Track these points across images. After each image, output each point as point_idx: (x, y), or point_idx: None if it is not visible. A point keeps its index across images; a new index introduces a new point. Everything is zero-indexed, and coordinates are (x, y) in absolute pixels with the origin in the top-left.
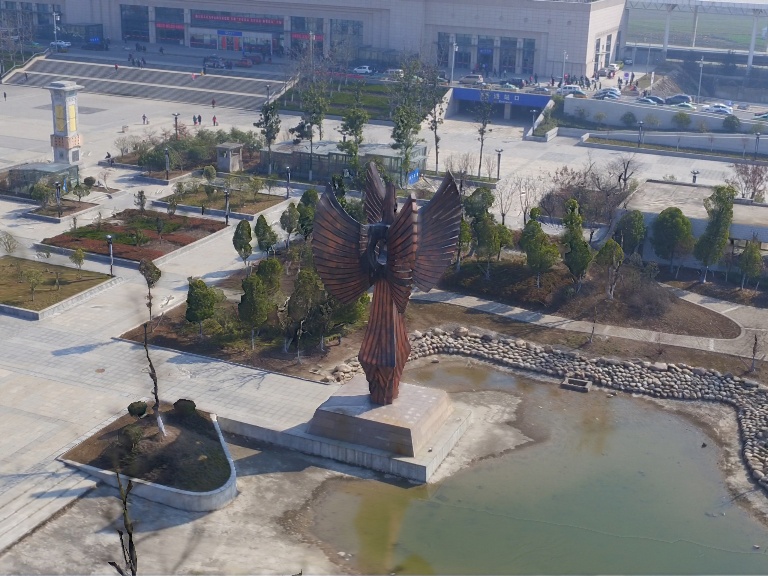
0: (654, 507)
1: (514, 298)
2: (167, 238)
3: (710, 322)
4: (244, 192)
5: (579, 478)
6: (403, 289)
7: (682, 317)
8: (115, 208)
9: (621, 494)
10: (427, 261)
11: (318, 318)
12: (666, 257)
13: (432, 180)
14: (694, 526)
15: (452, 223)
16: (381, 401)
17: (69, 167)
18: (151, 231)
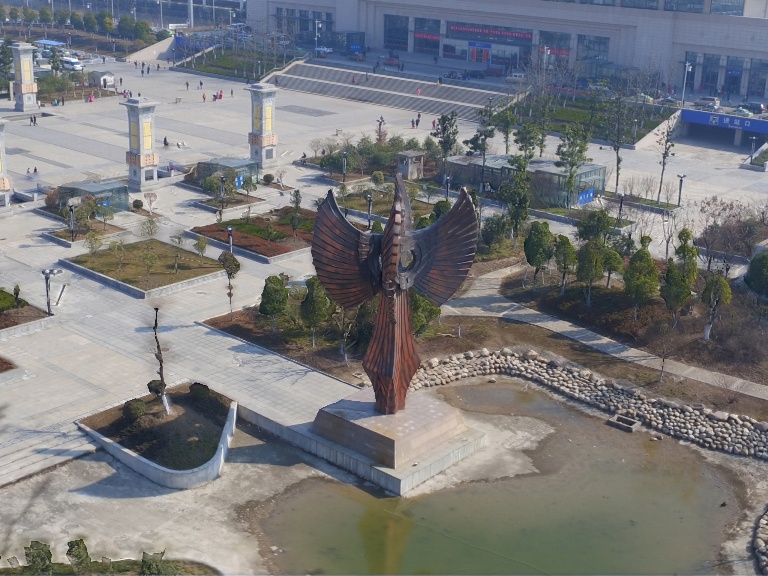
0: (622, 558)
1: (606, 327)
2: (303, 236)
3: None
4: None
5: (562, 516)
6: (386, 299)
7: None
8: (279, 205)
9: (596, 539)
10: (440, 276)
11: None
12: None
13: (607, 202)
14: None
15: (469, 240)
16: (383, 410)
17: (249, 163)
18: None
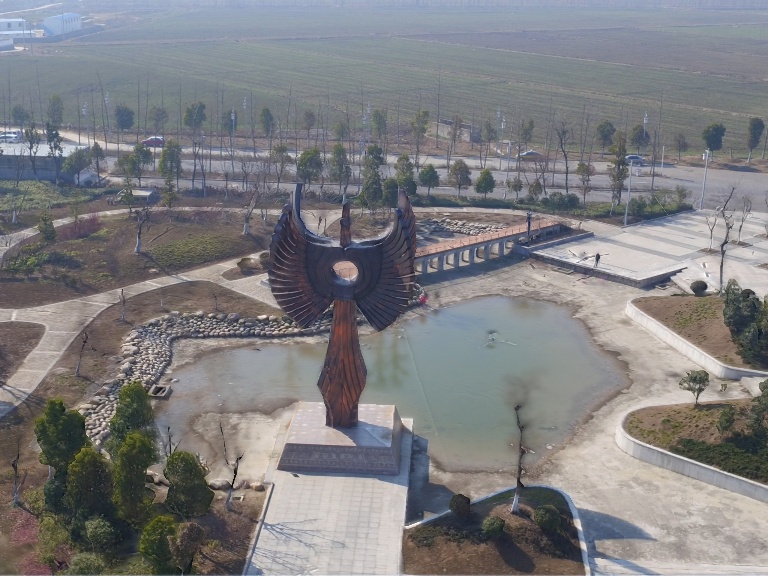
0: (372, 363)
1: None
2: None
3: (4, 330)
4: None
5: None
6: None
7: None
8: None
9: None
10: None
11: None
12: None
13: None
14: (388, 353)
15: None
16: None
17: None
18: None
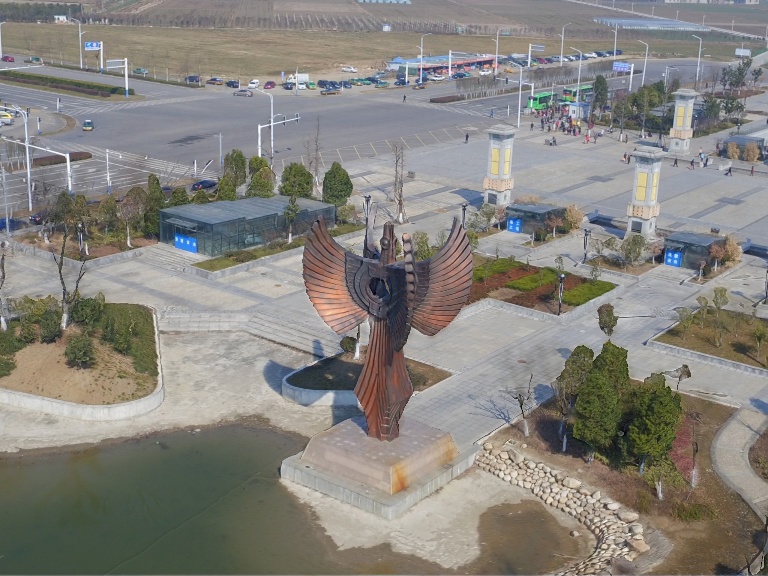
0: None
1: None
2: None
3: None
4: None
5: (248, 558)
6: None
7: None
8: None
9: (204, 575)
10: None
11: None
12: None
13: None
14: None
15: None
16: None
17: None
18: None
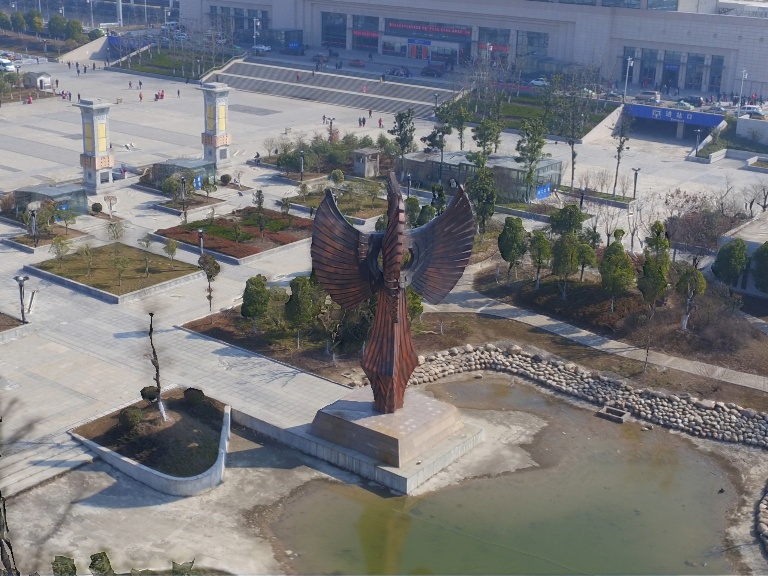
0: (633, 548)
1: (584, 320)
2: (270, 236)
3: None
4: (359, 197)
5: (568, 509)
6: (390, 299)
7: (758, 355)
8: (240, 205)
9: (604, 530)
10: (437, 273)
11: (366, 323)
12: (765, 291)
13: (564, 196)
14: (666, 573)
15: (465, 237)
16: (382, 409)
17: (206, 164)
18: (259, 229)
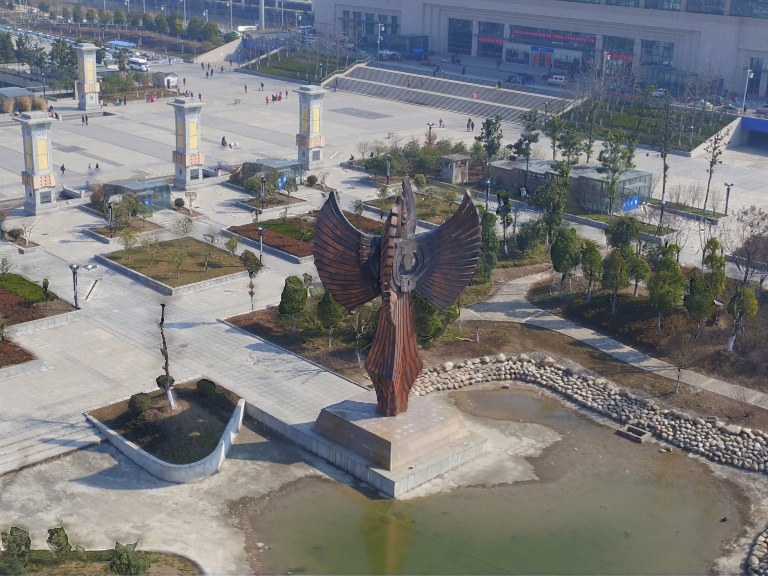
0: (610, 570)
1: (629, 336)
2: None
3: None
4: (434, 202)
5: (555, 525)
6: (383, 301)
7: None
8: (320, 206)
9: (586, 550)
10: (443, 279)
11: None
12: None
13: (652, 209)
14: None
15: (472, 244)
16: (384, 412)
17: (293, 164)
18: None
